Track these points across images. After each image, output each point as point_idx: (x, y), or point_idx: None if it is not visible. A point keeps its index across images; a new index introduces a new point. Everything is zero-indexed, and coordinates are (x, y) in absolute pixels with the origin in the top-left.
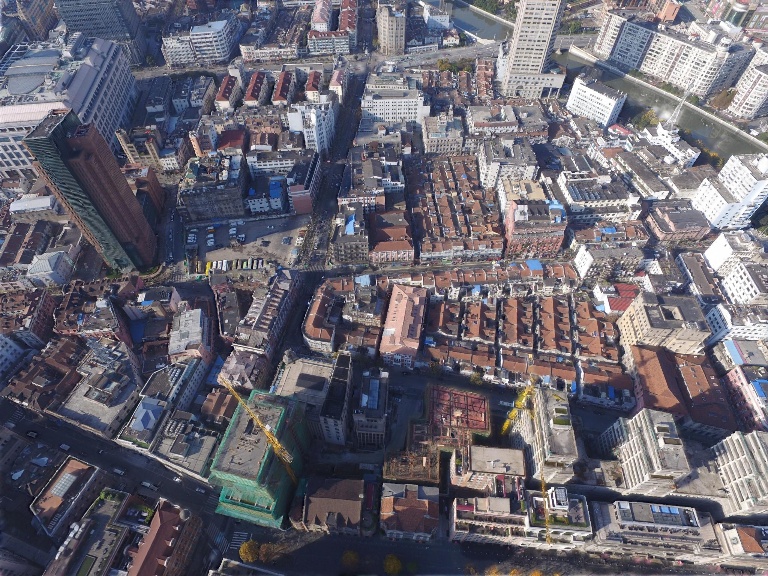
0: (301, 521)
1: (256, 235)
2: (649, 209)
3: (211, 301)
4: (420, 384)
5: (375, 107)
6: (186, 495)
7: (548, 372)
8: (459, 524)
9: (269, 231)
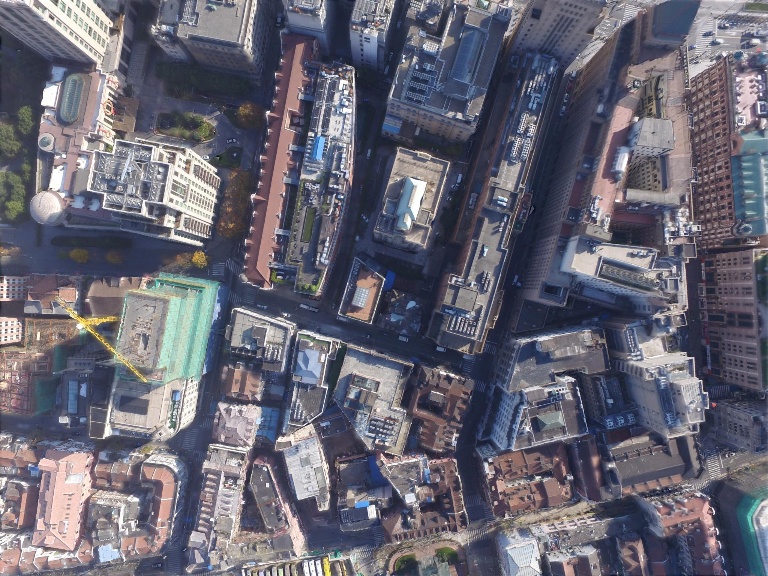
0: (148, 280)
1: None
2: None
3: (312, 519)
4: None
5: None
6: (275, 302)
7: None
8: (1, 282)
9: None
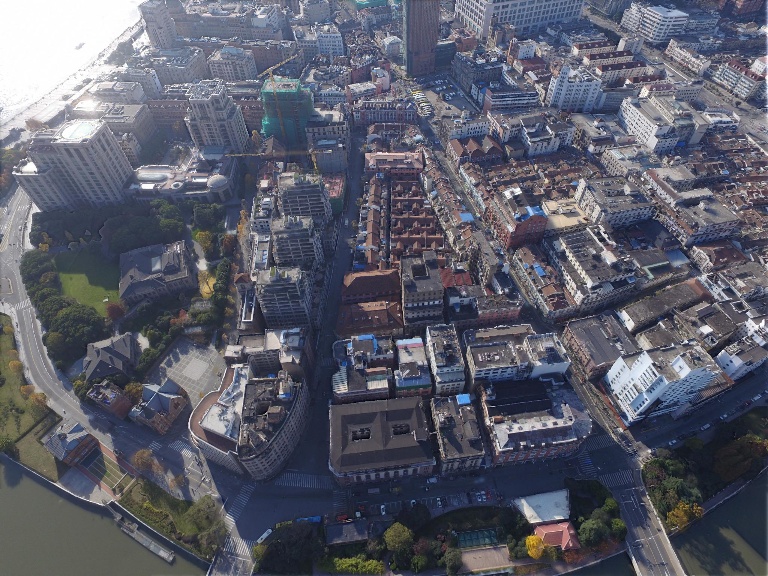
0: None
1: (454, 103)
2: (601, 314)
3: None
4: (356, 186)
5: (628, 112)
6: None
7: (369, 232)
8: None
9: (461, 107)
